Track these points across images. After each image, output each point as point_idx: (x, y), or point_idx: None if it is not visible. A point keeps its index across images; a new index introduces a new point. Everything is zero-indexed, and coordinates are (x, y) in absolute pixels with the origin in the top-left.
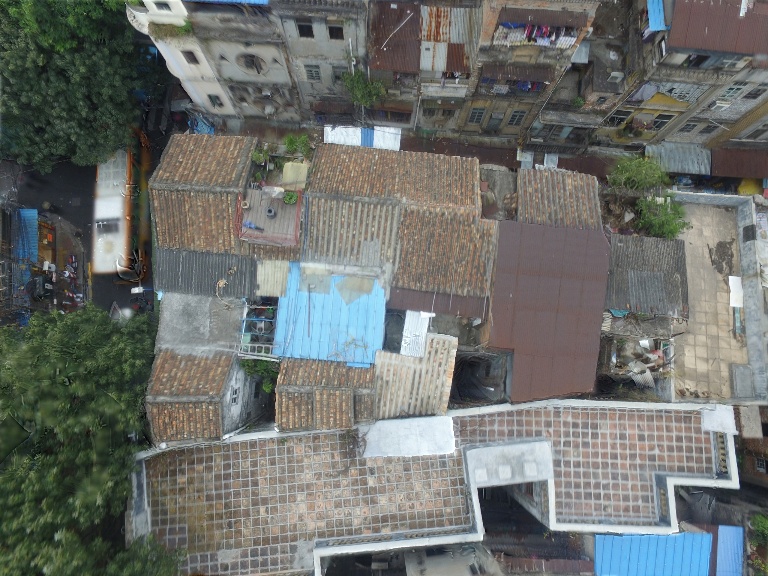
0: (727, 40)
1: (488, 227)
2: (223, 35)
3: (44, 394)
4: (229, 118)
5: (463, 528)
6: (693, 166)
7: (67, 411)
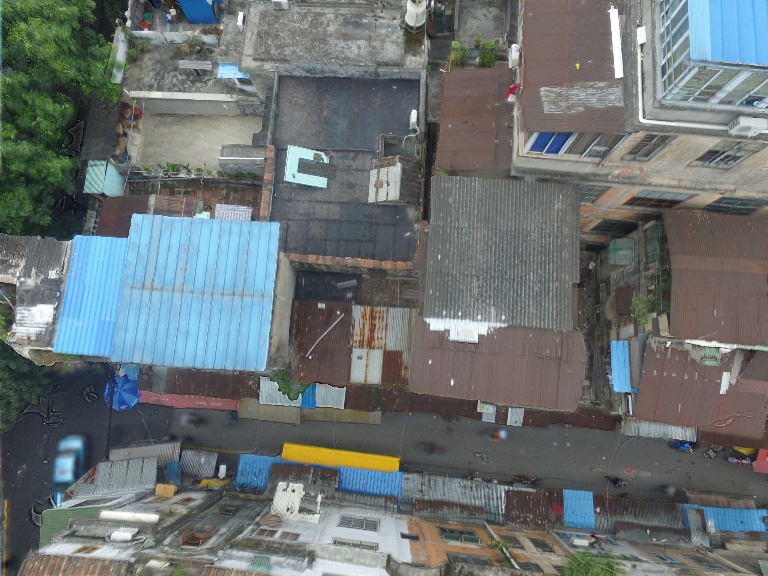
0: (705, 419)
1: None
2: None
3: None
4: None
5: None
6: (676, 433)
7: None
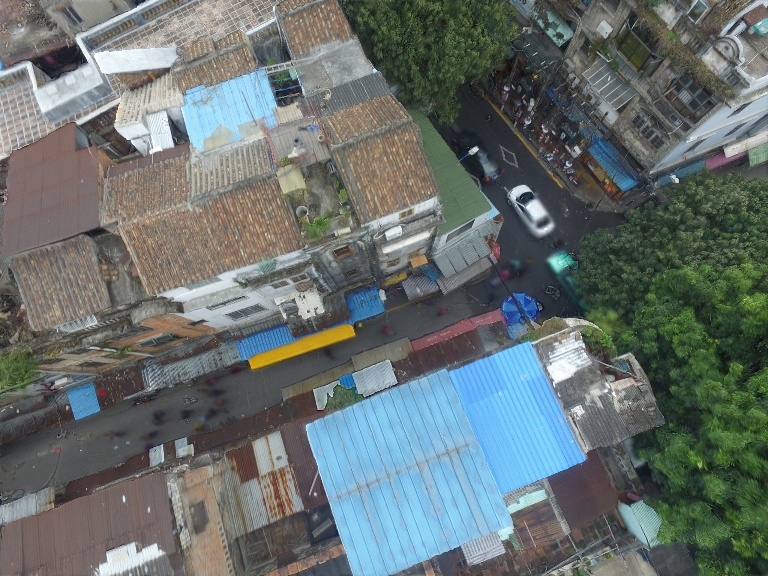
0: None
1: (110, 219)
2: (487, 353)
3: (508, 65)
4: None
5: (98, 46)
6: (1, 512)
7: (491, 71)
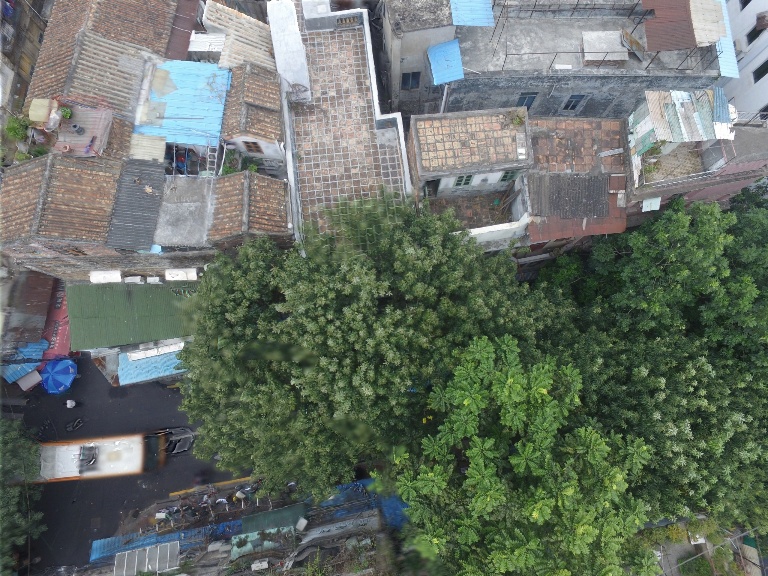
0: None
1: None
2: None
3: None
4: (8, 324)
5: None
6: None
7: None
